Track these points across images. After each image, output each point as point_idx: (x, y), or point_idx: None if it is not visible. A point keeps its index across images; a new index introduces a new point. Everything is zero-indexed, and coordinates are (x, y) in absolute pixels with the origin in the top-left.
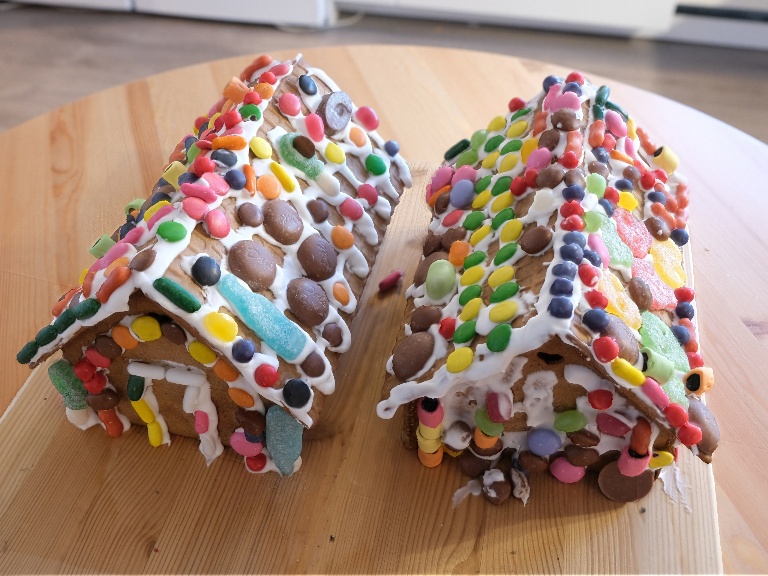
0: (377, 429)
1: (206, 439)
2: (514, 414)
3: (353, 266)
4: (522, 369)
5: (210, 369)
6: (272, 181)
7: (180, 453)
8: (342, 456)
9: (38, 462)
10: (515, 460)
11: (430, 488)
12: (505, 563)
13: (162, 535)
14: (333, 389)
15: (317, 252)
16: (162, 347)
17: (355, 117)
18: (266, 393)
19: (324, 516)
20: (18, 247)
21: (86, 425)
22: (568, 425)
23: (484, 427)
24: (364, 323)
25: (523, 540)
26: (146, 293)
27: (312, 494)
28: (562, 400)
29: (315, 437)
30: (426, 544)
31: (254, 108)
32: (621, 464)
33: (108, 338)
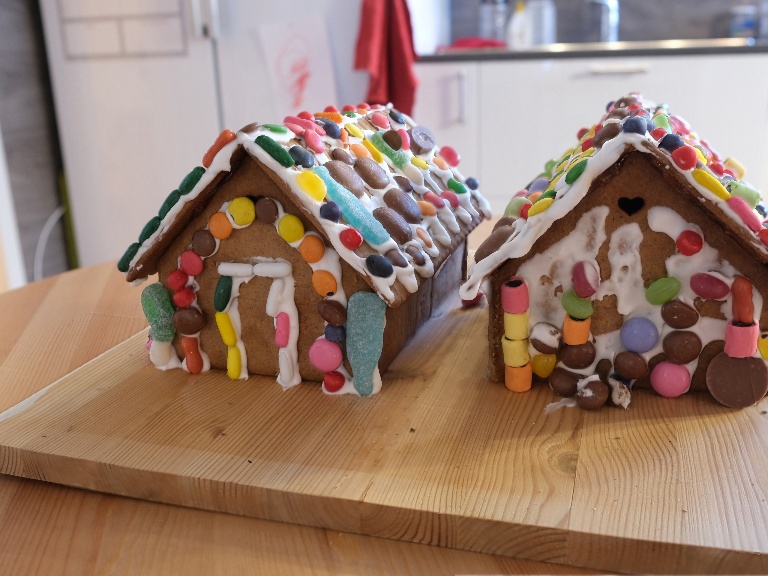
0: (461, 373)
1: (285, 356)
2: (603, 300)
3: (436, 234)
4: (605, 226)
5: (297, 258)
6: (363, 147)
7: (257, 384)
8: (424, 386)
9: (115, 386)
10: (611, 375)
11: (519, 403)
12: (608, 444)
13: (231, 426)
14: (415, 288)
15: (402, 197)
16: (253, 238)
17: (438, 154)
18: (350, 256)
19: (404, 418)
20: (123, 304)
21: (167, 365)
22: (660, 287)
23: (572, 304)
24: (447, 321)
25: (627, 431)
26: (248, 148)
27: (391, 406)
28: (651, 268)
29: (396, 377)
30: (517, 434)
31: (350, 112)
32: (727, 344)
33: (205, 231)
